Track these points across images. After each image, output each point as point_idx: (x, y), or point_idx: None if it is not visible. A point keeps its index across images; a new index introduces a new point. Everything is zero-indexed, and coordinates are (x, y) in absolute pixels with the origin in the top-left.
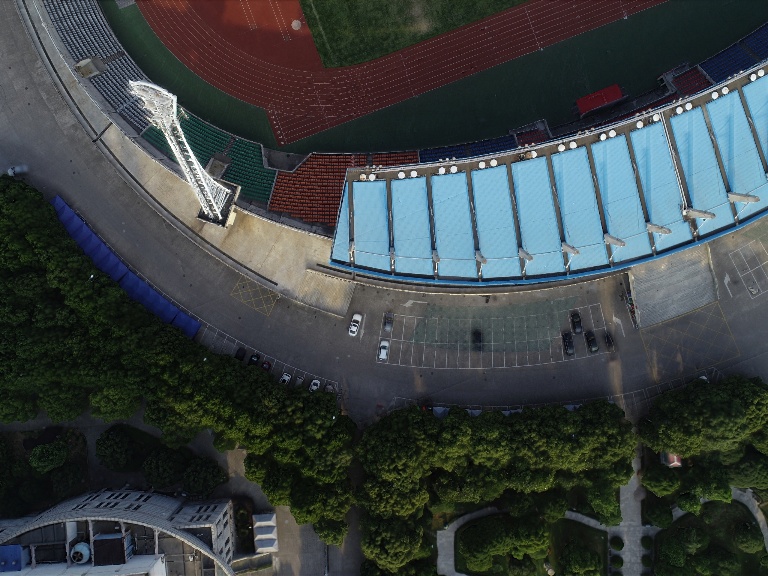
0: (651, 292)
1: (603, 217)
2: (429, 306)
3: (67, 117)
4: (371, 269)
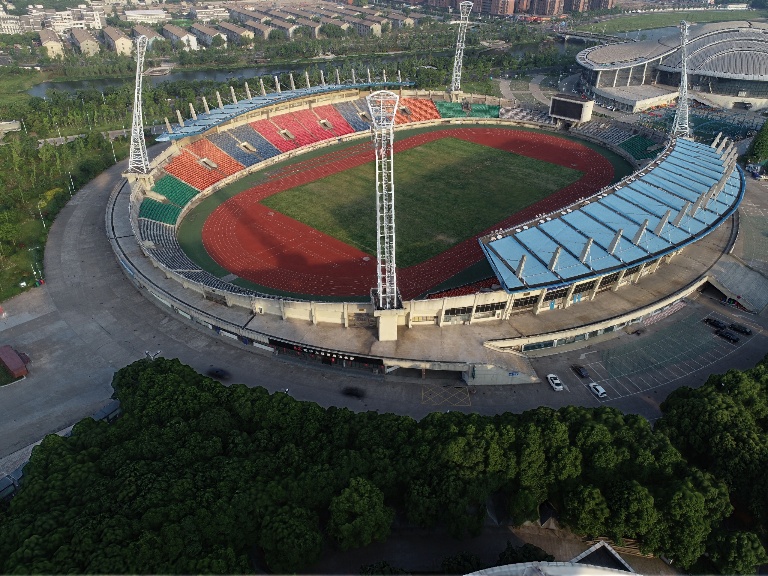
0: (735, 289)
1: (660, 218)
2: (600, 352)
3: (199, 342)
4: (544, 285)
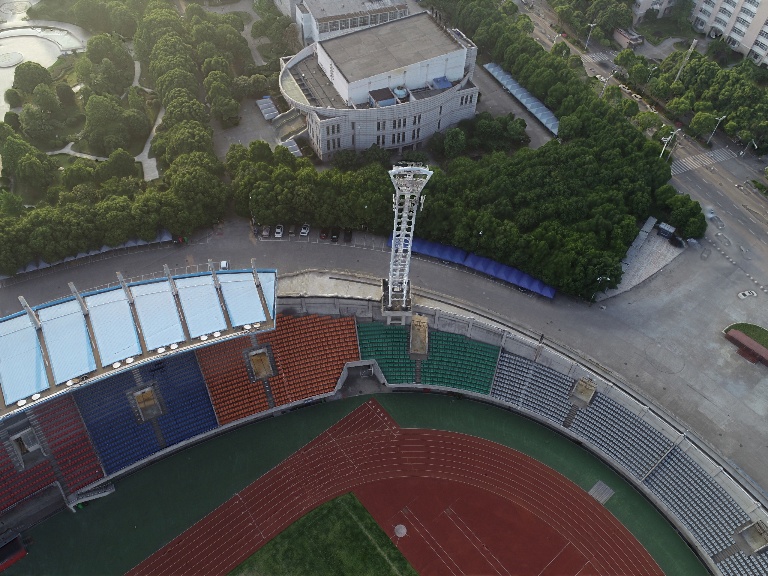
0: None
1: None
2: None
3: None
4: None
